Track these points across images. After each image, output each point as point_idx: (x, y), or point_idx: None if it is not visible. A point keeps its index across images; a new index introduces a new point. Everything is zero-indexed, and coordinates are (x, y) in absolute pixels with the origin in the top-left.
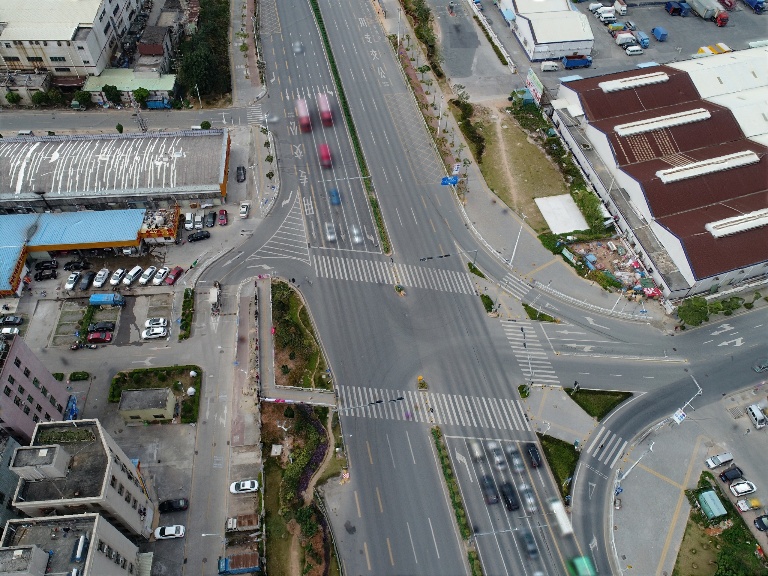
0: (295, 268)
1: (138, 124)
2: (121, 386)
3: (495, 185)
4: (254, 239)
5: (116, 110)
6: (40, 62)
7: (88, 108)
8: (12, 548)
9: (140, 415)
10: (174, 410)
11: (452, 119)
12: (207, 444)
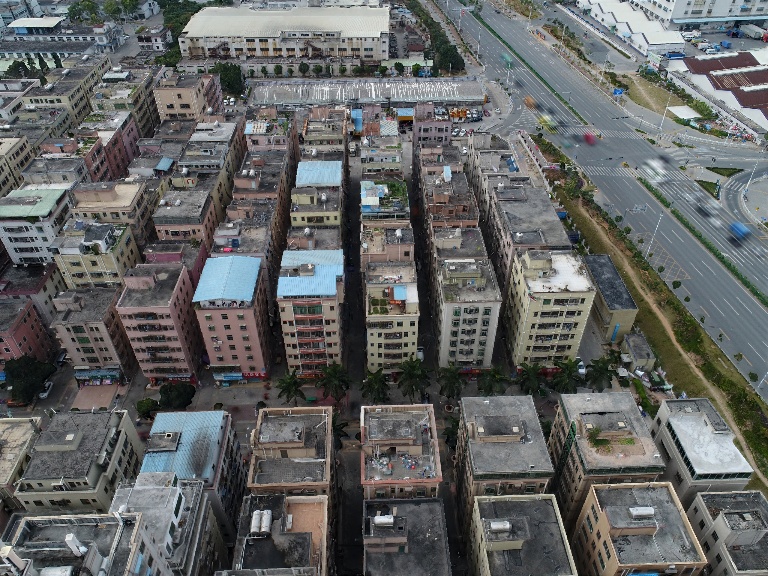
0: None
1: (424, 76)
2: None
3: (640, 102)
4: (508, 121)
5: (399, 77)
6: (358, 52)
7: (383, 77)
8: (490, 151)
9: None
10: None
11: (604, 79)
12: None
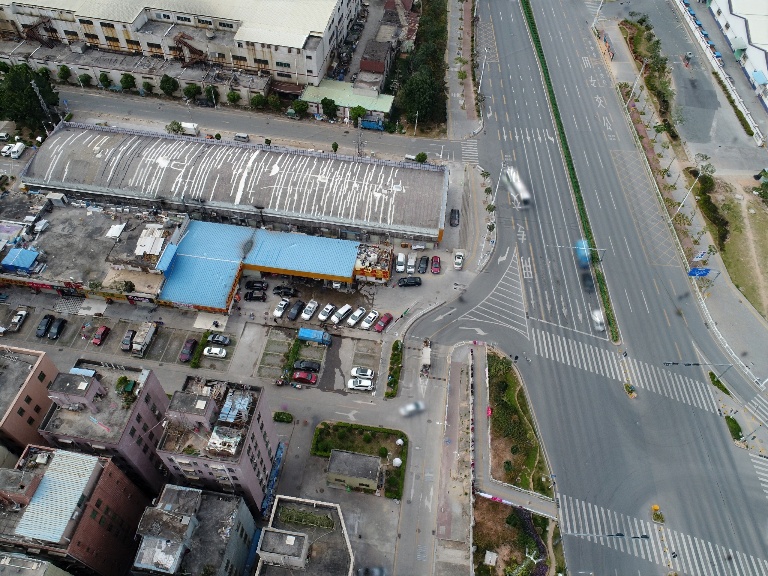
0: (512, 339)
1: (356, 146)
2: (324, 438)
3: (741, 281)
4: (467, 296)
5: (329, 124)
6: (265, 65)
7: (302, 118)
8: None
9: (346, 480)
10: (378, 480)
11: None
12: (411, 528)
